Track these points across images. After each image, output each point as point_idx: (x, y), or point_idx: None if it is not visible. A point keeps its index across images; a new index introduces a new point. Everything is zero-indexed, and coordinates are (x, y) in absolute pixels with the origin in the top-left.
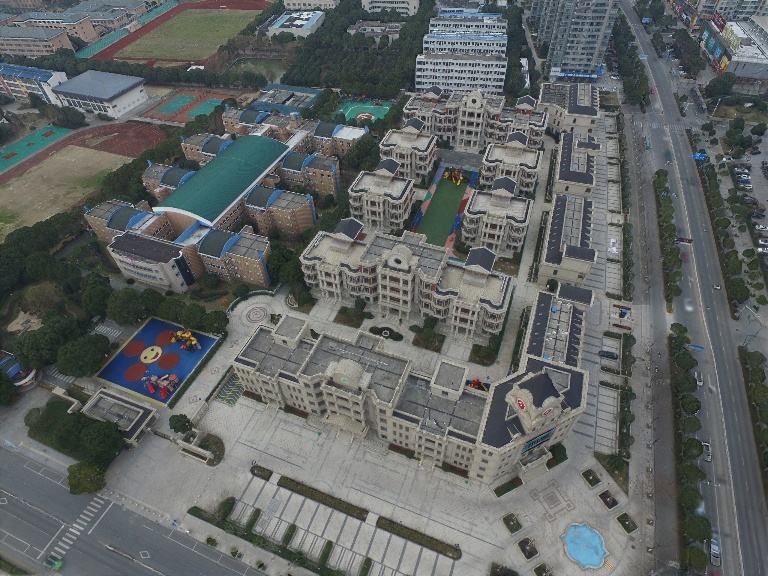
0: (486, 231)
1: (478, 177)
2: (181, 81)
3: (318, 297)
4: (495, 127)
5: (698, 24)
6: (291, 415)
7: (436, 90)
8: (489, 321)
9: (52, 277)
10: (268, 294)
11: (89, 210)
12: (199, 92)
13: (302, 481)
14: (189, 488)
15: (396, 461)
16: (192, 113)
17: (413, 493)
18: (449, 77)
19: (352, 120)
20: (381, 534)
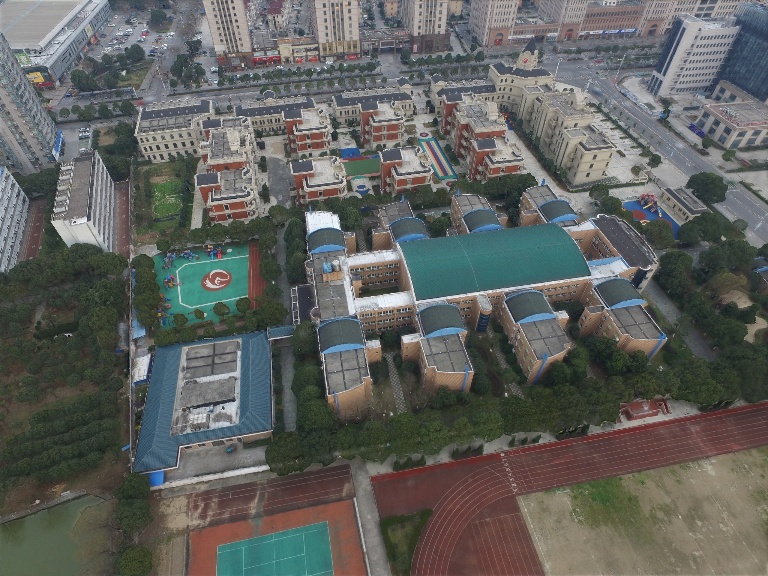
0: None
1: None
2: None
3: None
4: None
5: None
6: None
7: None
8: None
9: None
10: None
11: None
12: None
13: None
14: (658, 168)
15: None
16: (313, 568)
17: None
18: None
19: None
20: None
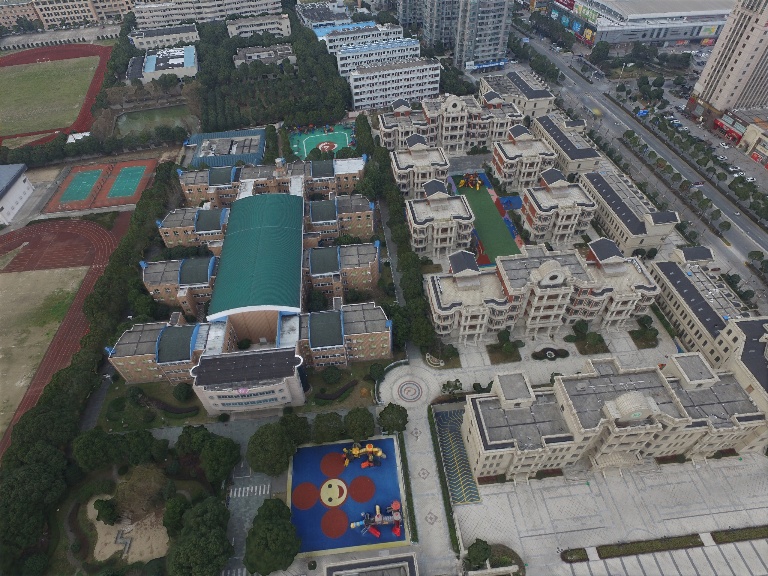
0: (561, 224)
1: (489, 177)
2: (66, 157)
3: (454, 346)
4: (477, 126)
5: (538, 6)
6: (545, 479)
7: (404, 103)
8: (645, 304)
9: (120, 458)
10: (401, 364)
11: (109, 351)
12: (101, 164)
13: (618, 541)
14: None
15: (673, 472)
16: (115, 191)
17: (713, 494)
18: (386, 89)
19: (340, 152)
20: (727, 549)
